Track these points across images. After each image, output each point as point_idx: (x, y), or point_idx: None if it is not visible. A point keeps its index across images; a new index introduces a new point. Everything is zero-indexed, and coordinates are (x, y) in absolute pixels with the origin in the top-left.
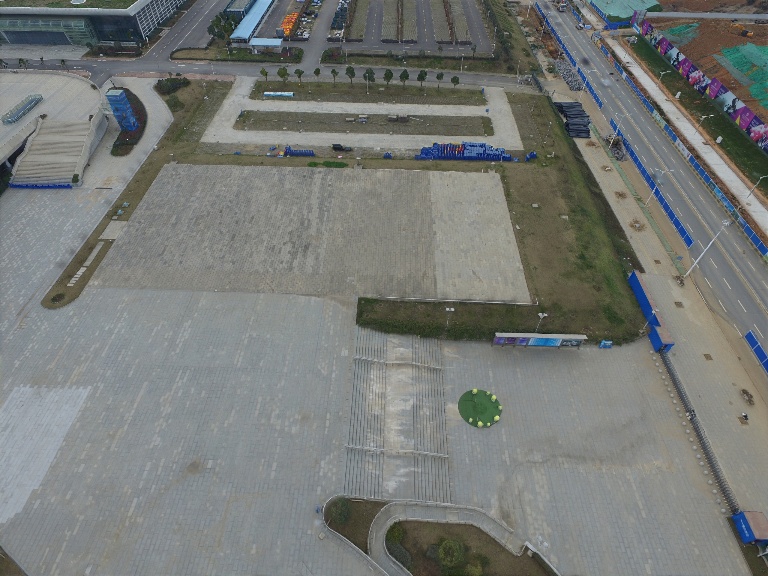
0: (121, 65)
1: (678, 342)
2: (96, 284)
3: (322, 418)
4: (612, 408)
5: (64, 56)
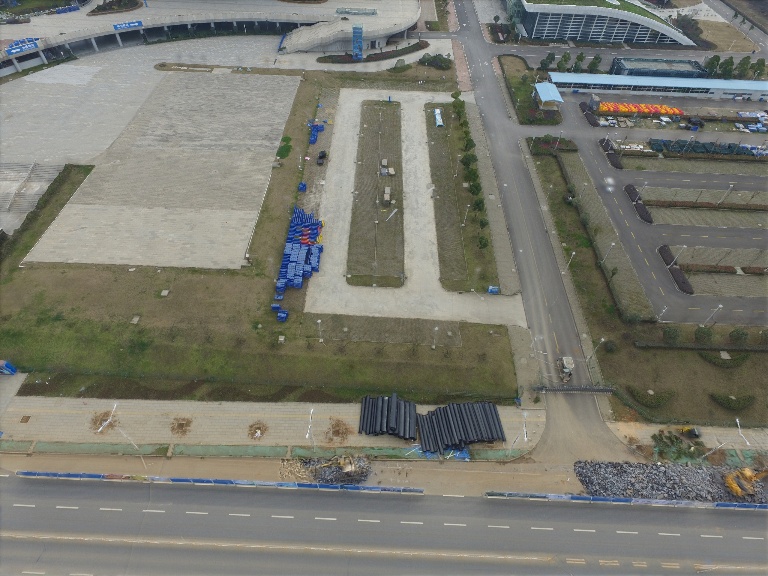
0: (475, 39)
1: None
2: (169, 73)
3: (3, 152)
4: None
5: (485, 17)
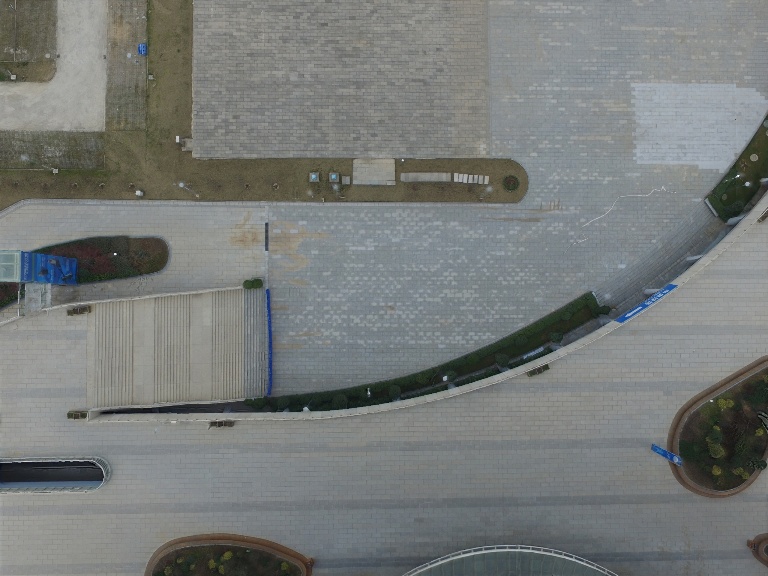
0: None
1: None
2: (485, 146)
3: None
4: None
5: None
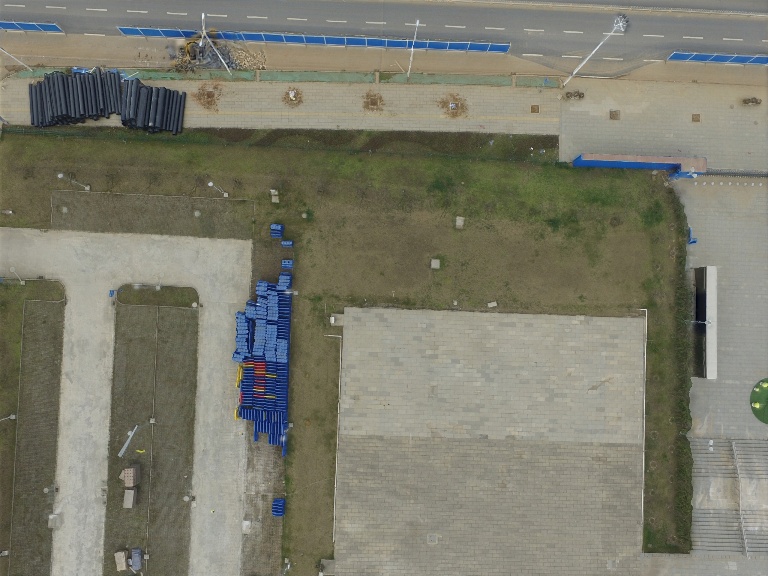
0: None
1: (677, 144)
2: None
3: None
4: (767, 256)
5: None
